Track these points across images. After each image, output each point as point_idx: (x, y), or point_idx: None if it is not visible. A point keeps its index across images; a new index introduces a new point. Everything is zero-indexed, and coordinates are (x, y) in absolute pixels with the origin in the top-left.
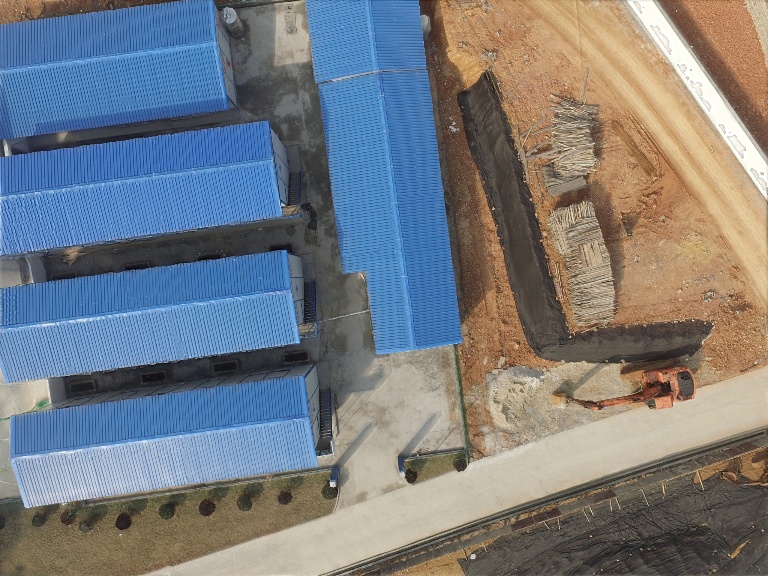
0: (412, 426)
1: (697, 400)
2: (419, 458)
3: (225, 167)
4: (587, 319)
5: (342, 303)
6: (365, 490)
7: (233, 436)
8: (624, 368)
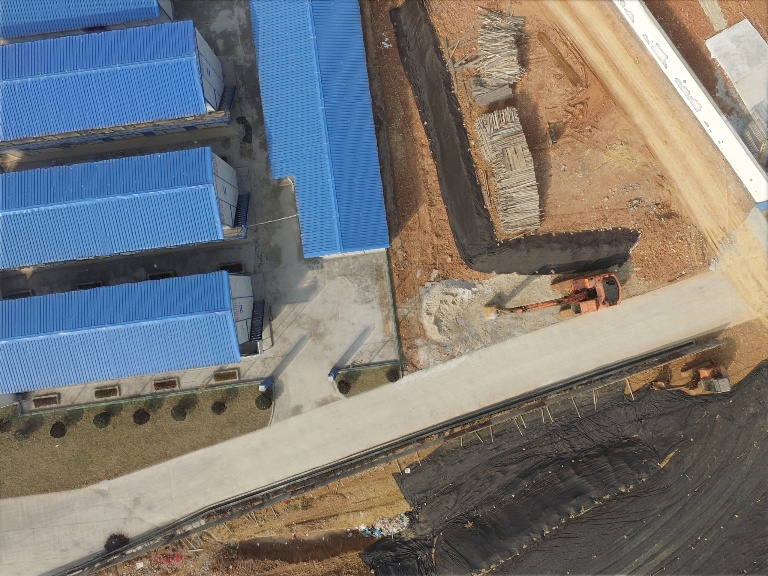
0: (346, 338)
1: (627, 311)
2: (352, 370)
3: (149, 63)
4: (513, 225)
5: (277, 216)
6: (300, 403)
7: (156, 329)
8: (555, 280)
